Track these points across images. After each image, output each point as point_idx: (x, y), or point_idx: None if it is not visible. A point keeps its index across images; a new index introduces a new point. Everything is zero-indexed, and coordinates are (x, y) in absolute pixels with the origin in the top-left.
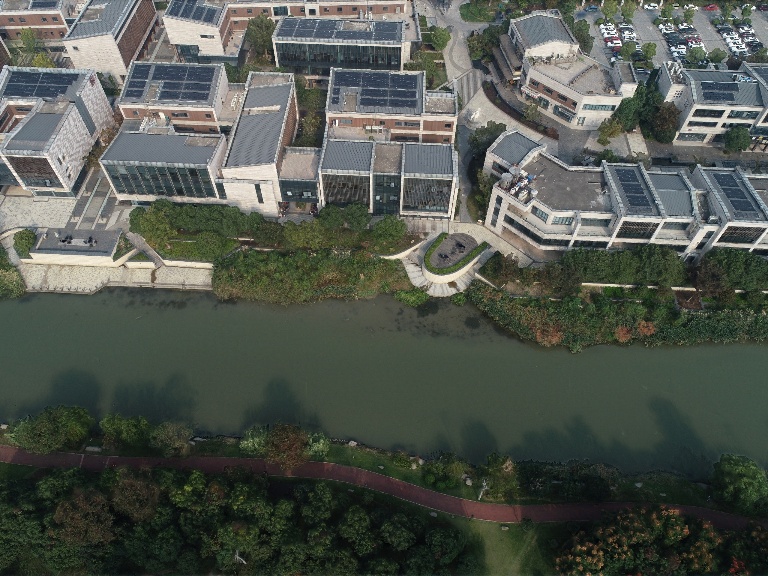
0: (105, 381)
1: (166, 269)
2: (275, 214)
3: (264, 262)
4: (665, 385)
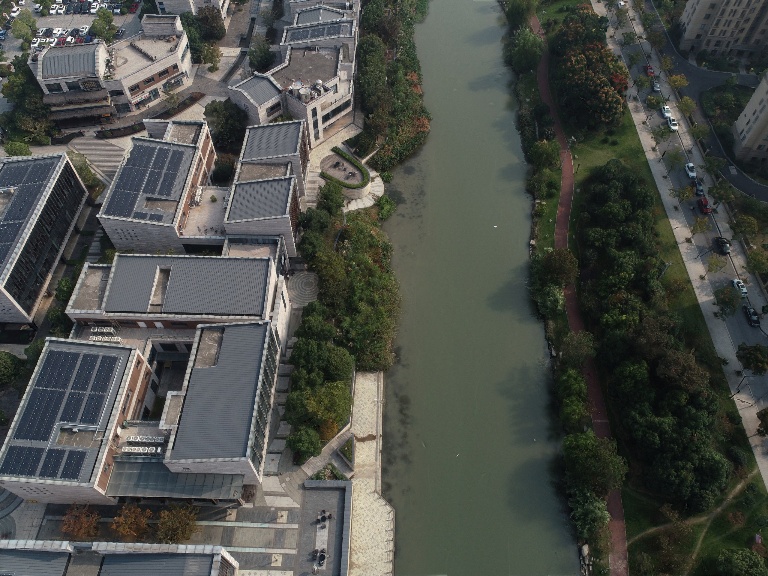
0: (508, 459)
1: (355, 426)
2: (289, 308)
3: (354, 317)
4: (452, 81)
